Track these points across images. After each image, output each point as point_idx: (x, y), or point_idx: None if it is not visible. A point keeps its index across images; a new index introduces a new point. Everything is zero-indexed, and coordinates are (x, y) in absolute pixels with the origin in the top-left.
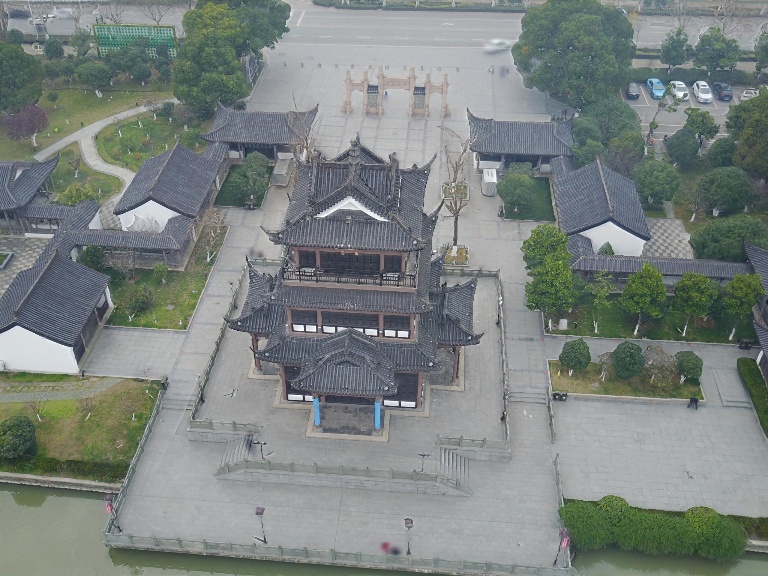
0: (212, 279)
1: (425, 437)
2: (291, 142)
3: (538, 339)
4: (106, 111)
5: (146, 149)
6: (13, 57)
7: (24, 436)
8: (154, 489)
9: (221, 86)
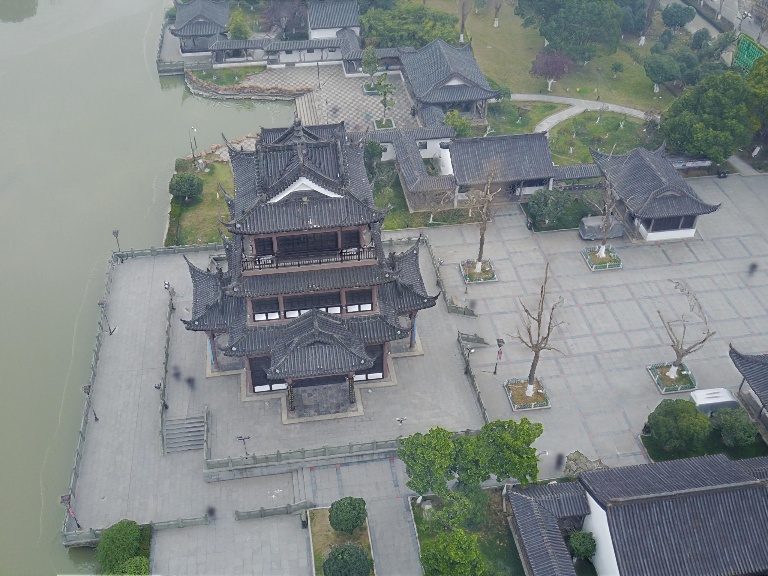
0: (407, 231)
1: (216, 403)
2: (631, 208)
3: (399, 491)
4: (634, 102)
5: (588, 141)
6: (593, 12)
7: (182, 187)
8: (161, 267)
9: (687, 131)
